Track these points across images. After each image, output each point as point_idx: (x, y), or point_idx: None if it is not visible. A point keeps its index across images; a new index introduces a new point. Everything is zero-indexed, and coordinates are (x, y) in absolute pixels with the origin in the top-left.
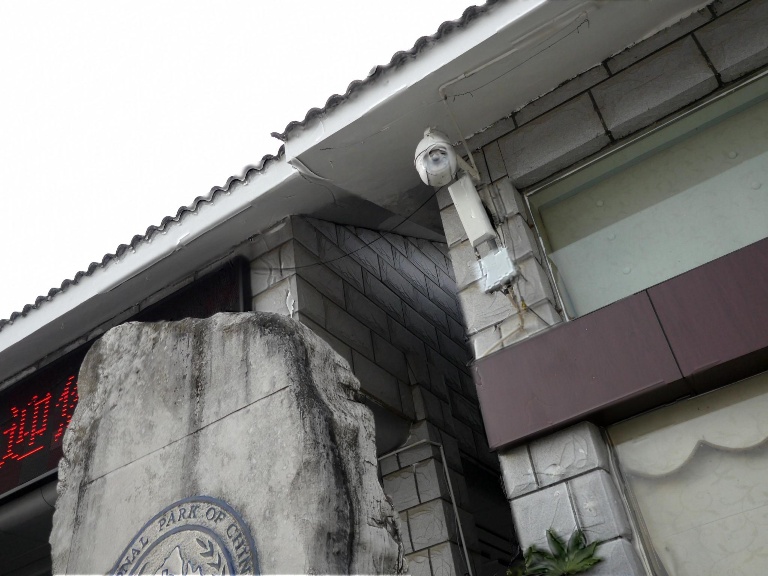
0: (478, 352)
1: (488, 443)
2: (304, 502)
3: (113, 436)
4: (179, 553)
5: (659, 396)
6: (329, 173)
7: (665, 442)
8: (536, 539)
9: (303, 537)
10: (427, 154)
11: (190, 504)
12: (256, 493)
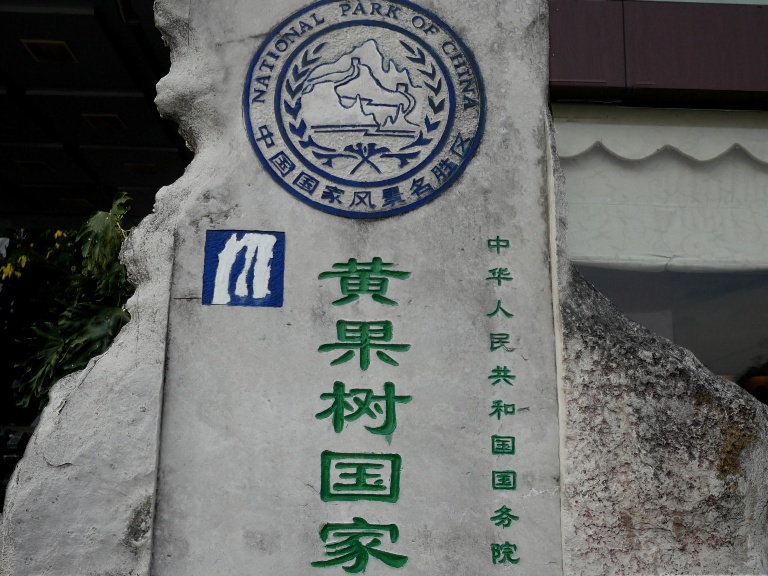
0: None
1: None
2: (538, 51)
3: None
4: (376, 47)
5: (601, 93)
6: None
7: (589, 130)
8: None
9: (540, 82)
10: None
11: (388, 2)
12: (481, 22)
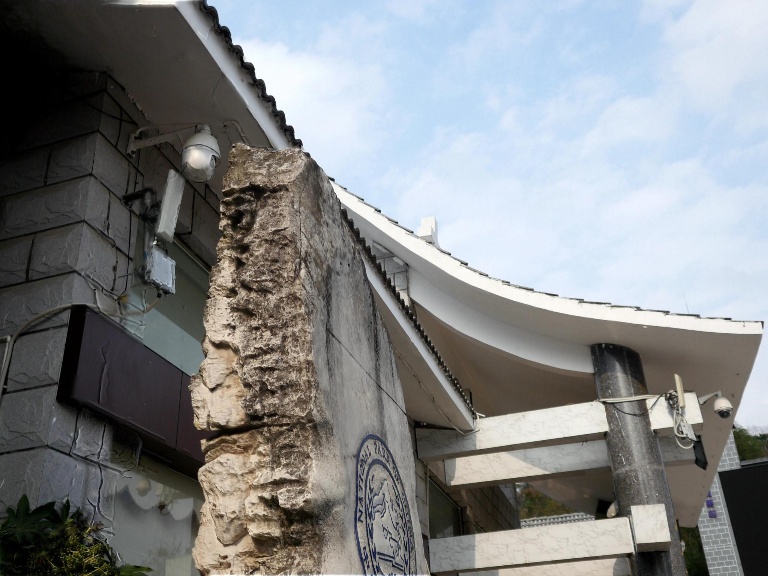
0: (102, 305)
1: (100, 399)
2: None
3: (341, 308)
4: None
5: None
6: (132, 18)
7: None
8: (82, 502)
9: None
10: (211, 153)
11: None
12: None
